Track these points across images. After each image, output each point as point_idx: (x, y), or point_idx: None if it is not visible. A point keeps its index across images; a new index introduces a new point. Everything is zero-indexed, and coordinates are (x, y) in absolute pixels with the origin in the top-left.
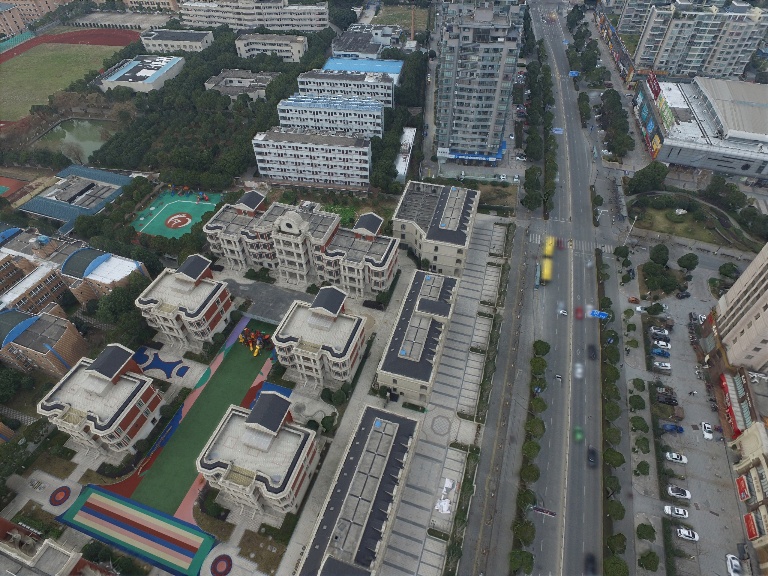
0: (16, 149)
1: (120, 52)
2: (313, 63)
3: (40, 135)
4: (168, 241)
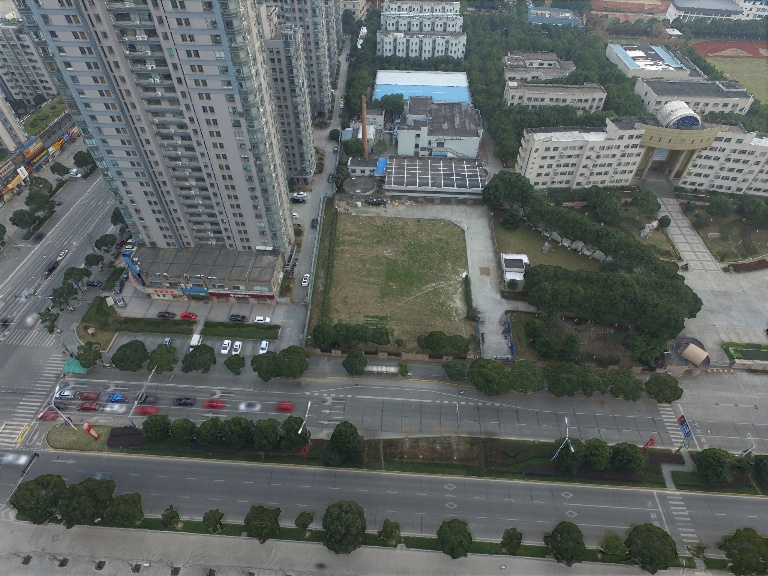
0: (630, 22)
1: None
2: None
3: None
4: None
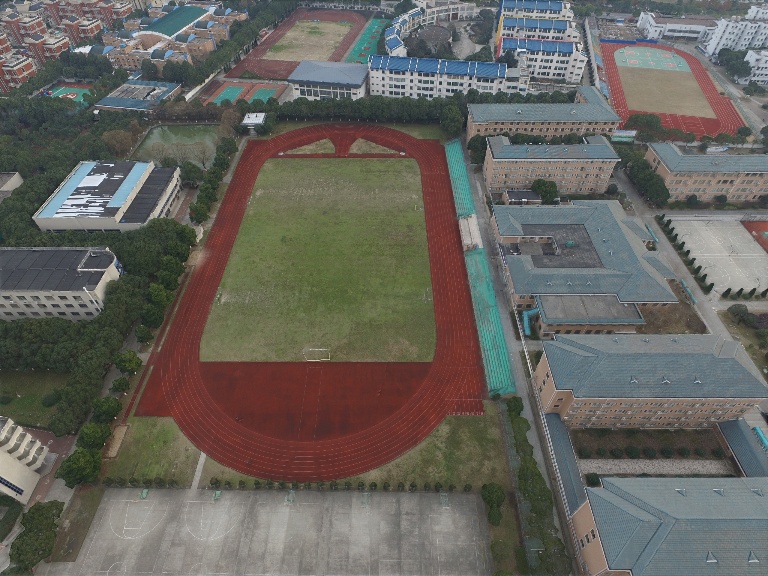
0: (209, 106)
1: (153, 228)
2: None
3: None
4: (59, 63)
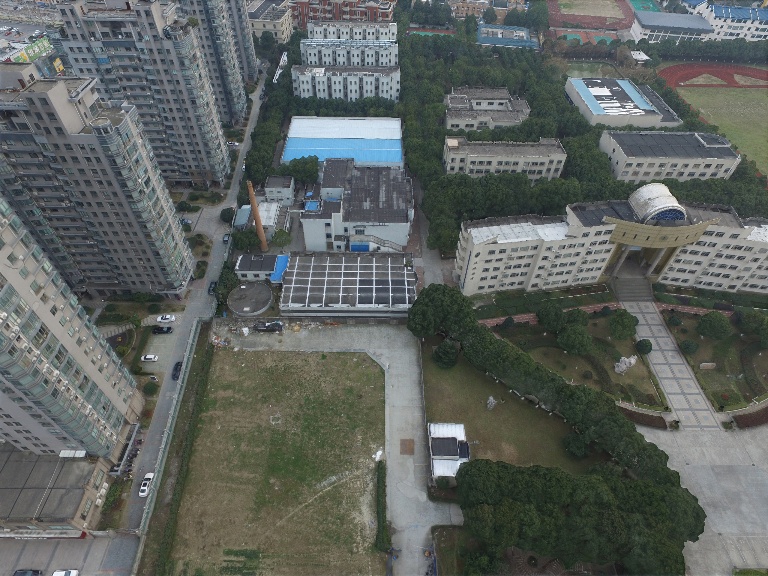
0: None
1: None
2: (415, 133)
3: (625, 77)
4: (411, 9)
